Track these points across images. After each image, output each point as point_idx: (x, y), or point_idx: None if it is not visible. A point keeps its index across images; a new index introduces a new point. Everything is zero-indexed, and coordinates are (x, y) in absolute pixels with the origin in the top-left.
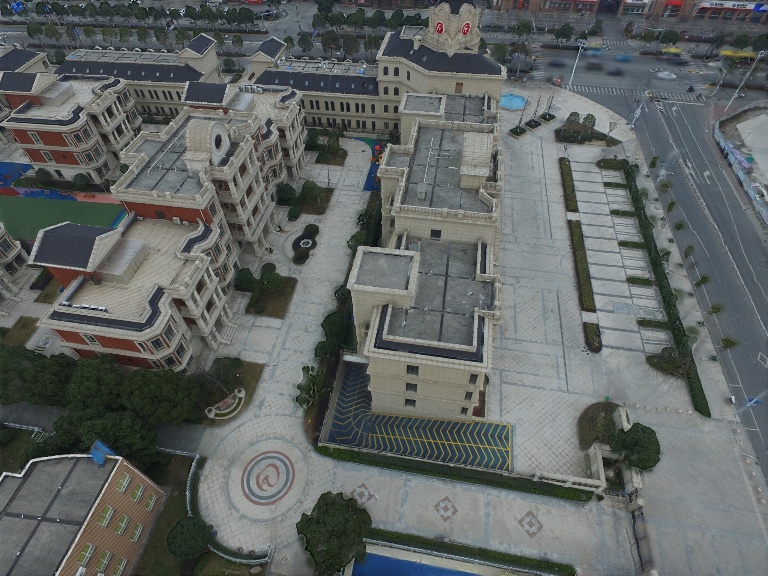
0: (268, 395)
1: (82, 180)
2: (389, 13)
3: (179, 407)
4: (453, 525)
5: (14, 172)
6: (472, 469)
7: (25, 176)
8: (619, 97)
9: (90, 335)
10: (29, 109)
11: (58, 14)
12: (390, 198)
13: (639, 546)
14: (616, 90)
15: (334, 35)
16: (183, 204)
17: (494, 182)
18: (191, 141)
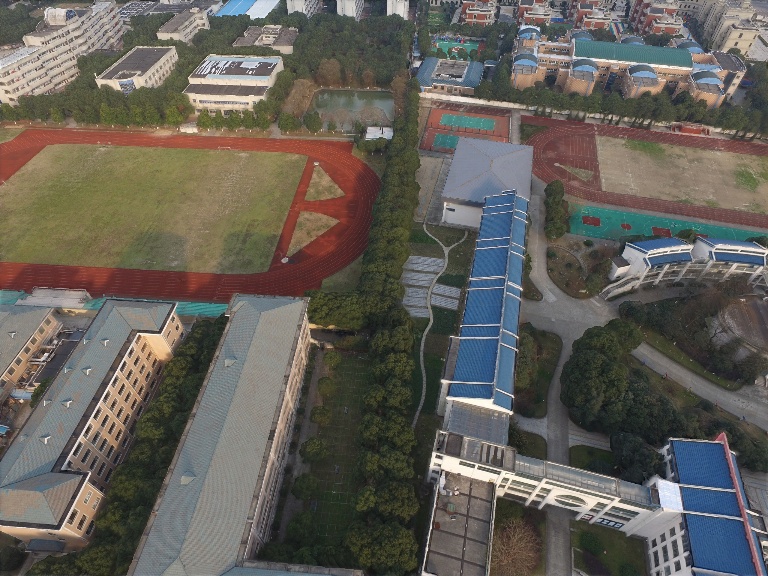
0: None
1: None
2: None
3: None
4: None
5: None
6: (751, 60)
7: (570, 19)
8: (762, 13)
9: (664, 28)
10: None
11: None
12: (719, 12)
13: None
14: (760, 11)
15: None
16: (673, 7)
17: (751, 6)
18: None
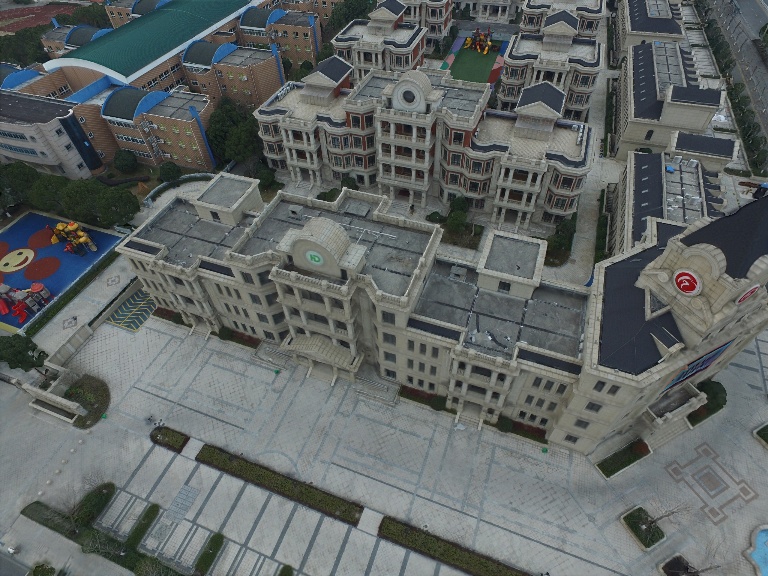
0: None
1: (491, 99)
2: None
3: (228, 150)
4: (102, 282)
5: None
6: None
7: None
8: None
9: None
10: (538, 40)
11: None
12: None
13: (5, 382)
14: None
15: None
16: None
17: None
18: None
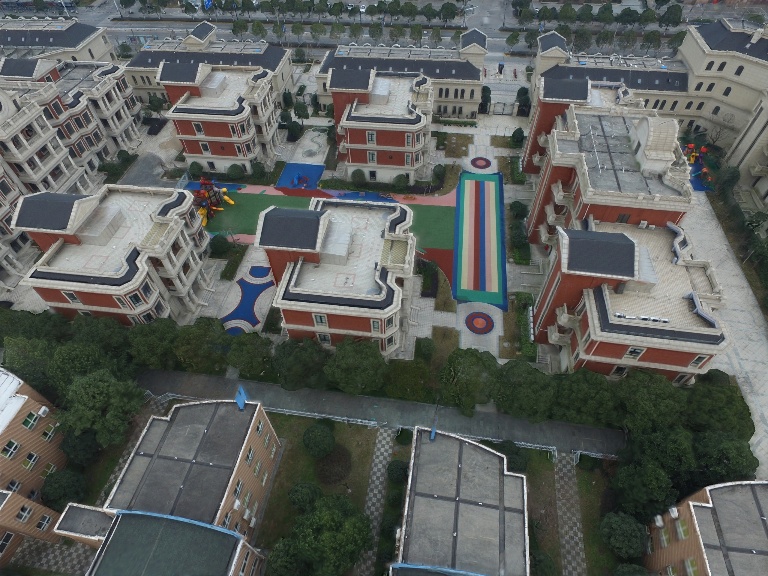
0: (763, 409)
1: (405, 181)
2: (578, 8)
3: (752, 425)
4: None
5: (310, 173)
6: None
7: (334, 178)
8: None
9: (642, 348)
10: (356, 107)
11: (245, 10)
12: None
13: None
14: None
15: (569, 30)
16: (672, 207)
17: None
18: (654, 140)
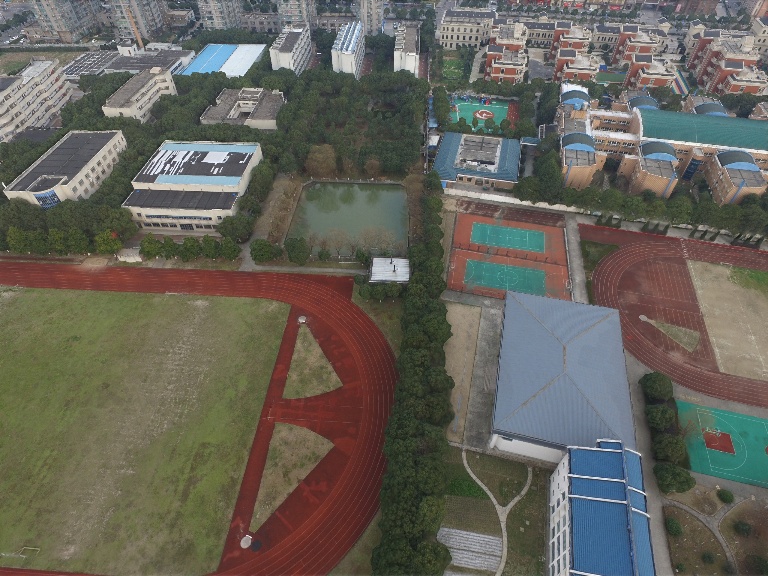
0: None
1: None
2: None
3: None
4: None
5: None
6: None
7: None
8: None
9: (744, 87)
10: None
11: (527, 11)
12: None
13: None
14: None
15: None
16: (752, 58)
17: None
18: (747, 42)
